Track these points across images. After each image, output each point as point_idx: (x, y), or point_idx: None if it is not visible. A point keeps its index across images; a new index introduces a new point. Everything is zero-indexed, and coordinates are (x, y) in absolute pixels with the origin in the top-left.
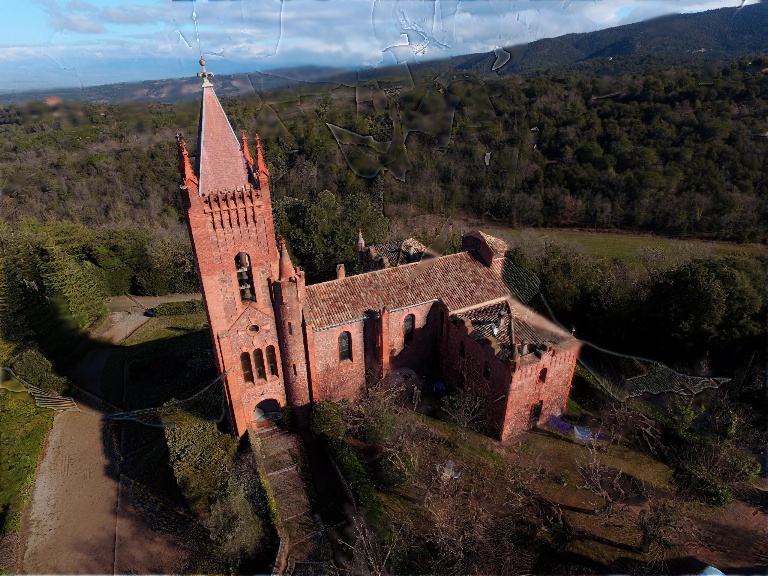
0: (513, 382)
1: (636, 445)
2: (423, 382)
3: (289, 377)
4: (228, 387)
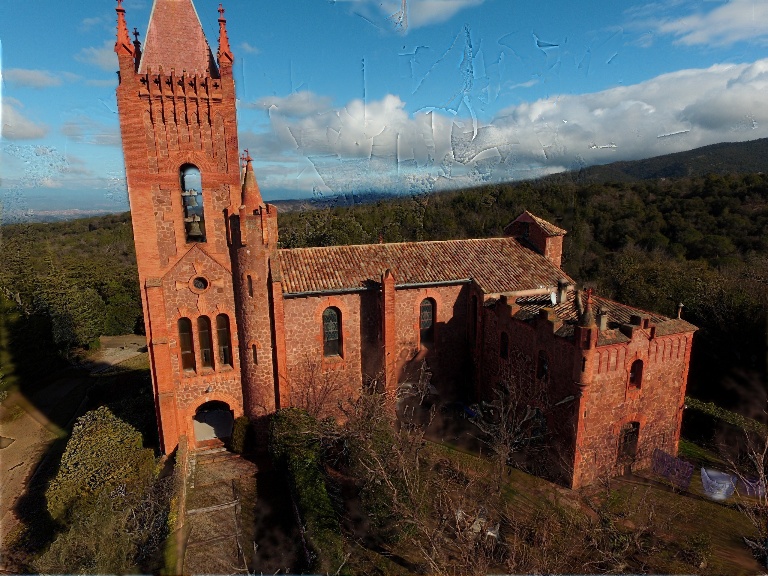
0: (587, 369)
1: None
2: (447, 404)
3: (247, 367)
4: (155, 369)
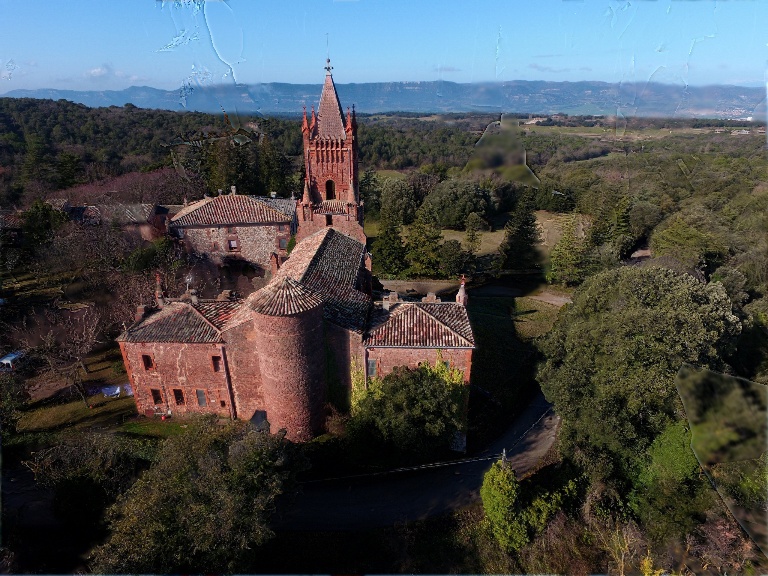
0: None
1: (59, 429)
2: None
3: None
4: None
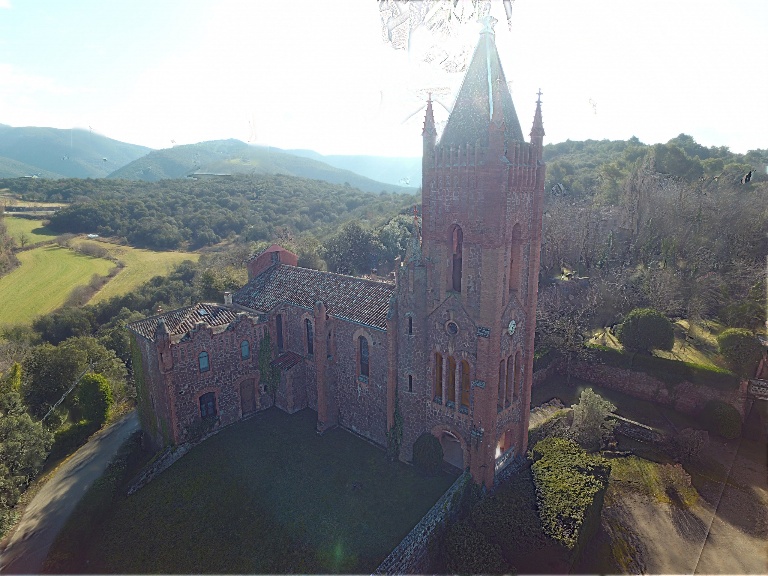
0: None
1: None
2: None
3: None
4: None
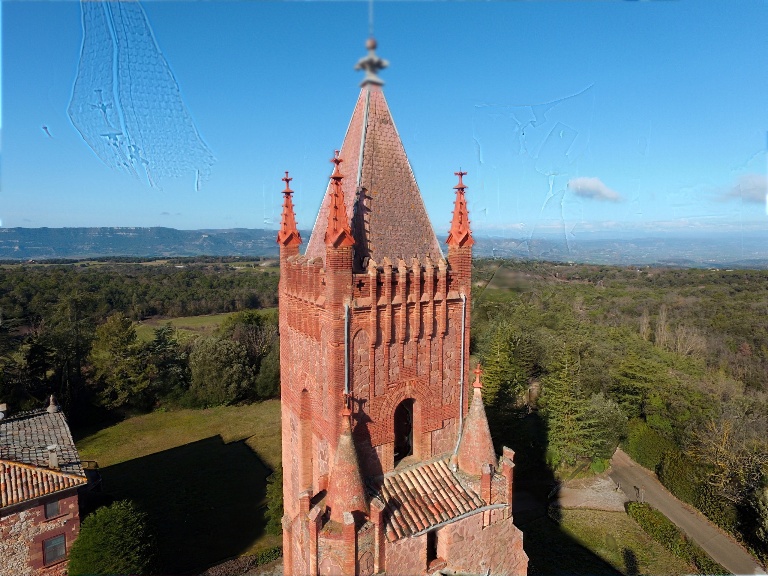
0: None
1: None
2: None
3: None
4: None
